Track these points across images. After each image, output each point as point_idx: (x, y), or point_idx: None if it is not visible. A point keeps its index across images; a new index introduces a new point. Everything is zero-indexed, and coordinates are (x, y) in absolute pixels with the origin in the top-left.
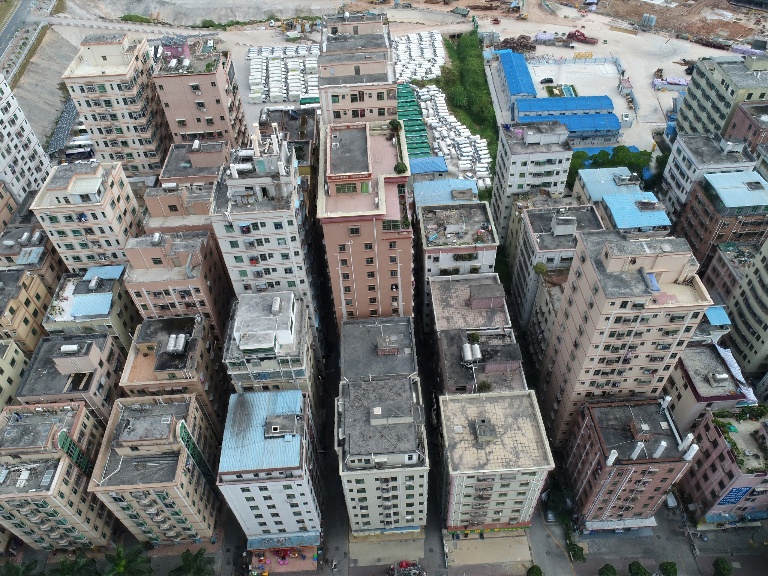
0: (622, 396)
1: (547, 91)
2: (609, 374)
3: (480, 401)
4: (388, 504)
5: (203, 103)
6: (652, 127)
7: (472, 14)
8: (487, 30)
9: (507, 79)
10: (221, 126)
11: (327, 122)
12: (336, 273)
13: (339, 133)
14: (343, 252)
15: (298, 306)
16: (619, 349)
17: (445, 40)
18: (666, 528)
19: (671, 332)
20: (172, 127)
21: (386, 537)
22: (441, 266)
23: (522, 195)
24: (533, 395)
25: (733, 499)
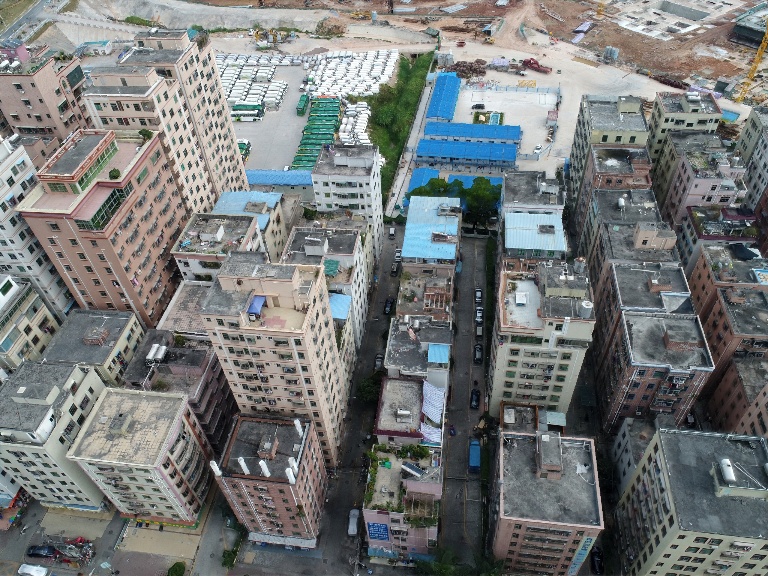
0: (287, 415)
1: (474, 117)
2: (259, 390)
3: (139, 398)
4: (37, 478)
5: (29, 101)
6: (560, 162)
7: (444, 35)
8: (444, 52)
9: (431, 102)
10: (49, 123)
11: (98, 127)
12: (58, 264)
13: (86, 138)
14: (54, 245)
15: (19, 289)
16: (249, 366)
17: (403, 59)
18: (337, 554)
19: (287, 356)
20: (9, 120)
21: (79, 513)
22: (194, 271)
23: (327, 214)
24: (184, 399)
25: (381, 535)
